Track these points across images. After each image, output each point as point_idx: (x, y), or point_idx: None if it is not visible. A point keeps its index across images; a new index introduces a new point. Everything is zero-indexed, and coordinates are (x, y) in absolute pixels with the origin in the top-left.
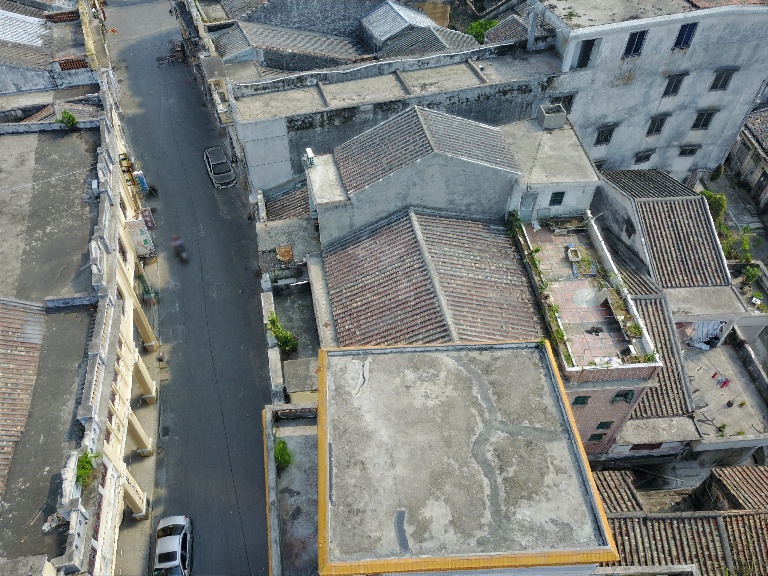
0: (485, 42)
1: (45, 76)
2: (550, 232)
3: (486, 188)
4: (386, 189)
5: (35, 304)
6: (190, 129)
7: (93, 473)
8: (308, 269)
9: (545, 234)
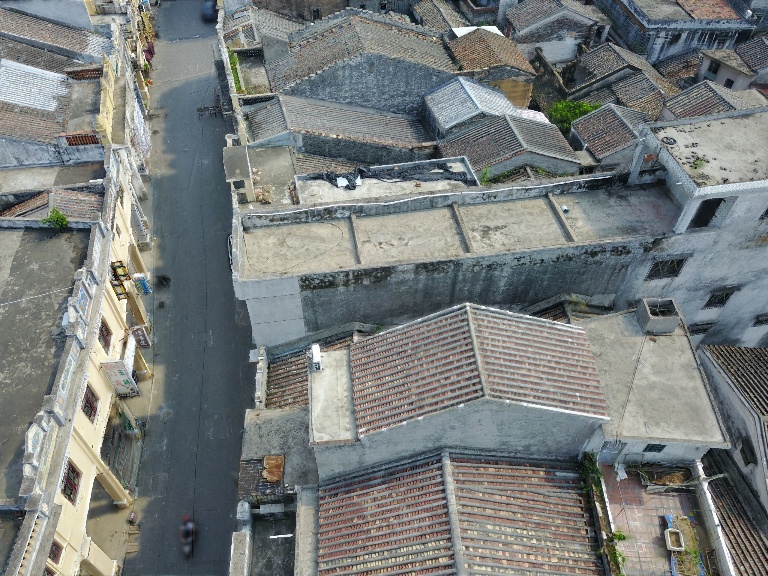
0: (571, 133)
1: (50, 151)
2: (640, 486)
3: (556, 431)
4: (412, 431)
5: None
6: (220, 200)
7: None
8: (296, 514)
9: (633, 488)
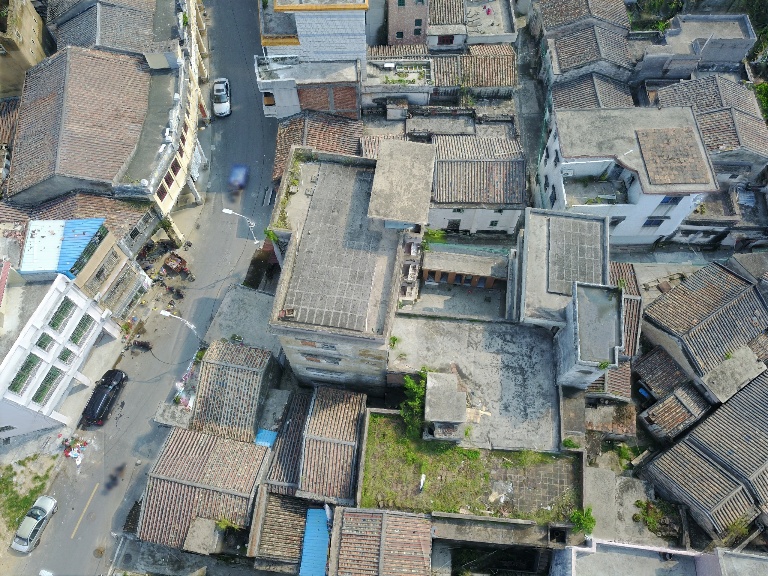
0: None
1: None
2: None
3: None
4: None
5: None
6: None
7: (188, 27)
8: None
9: None
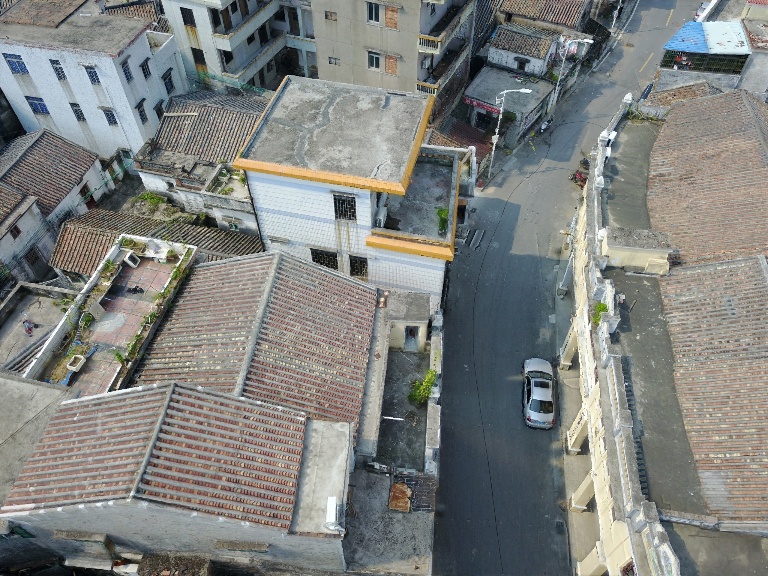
0: None
1: None
2: None
3: None
4: None
5: (730, 525)
6: None
7: None
8: None
9: None
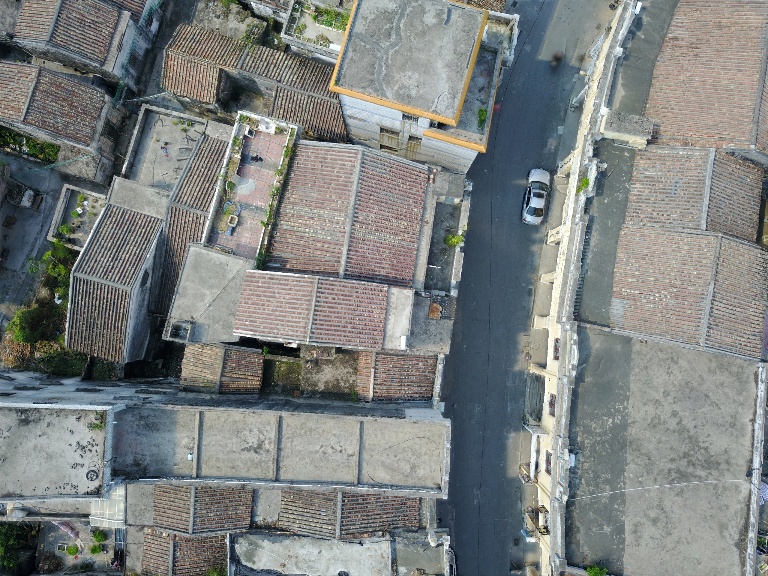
0: None
1: None
2: (234, 253)
3: None
4: None
5: (617, 331)
6: None
7: None
8: None
9: (239, 254)
